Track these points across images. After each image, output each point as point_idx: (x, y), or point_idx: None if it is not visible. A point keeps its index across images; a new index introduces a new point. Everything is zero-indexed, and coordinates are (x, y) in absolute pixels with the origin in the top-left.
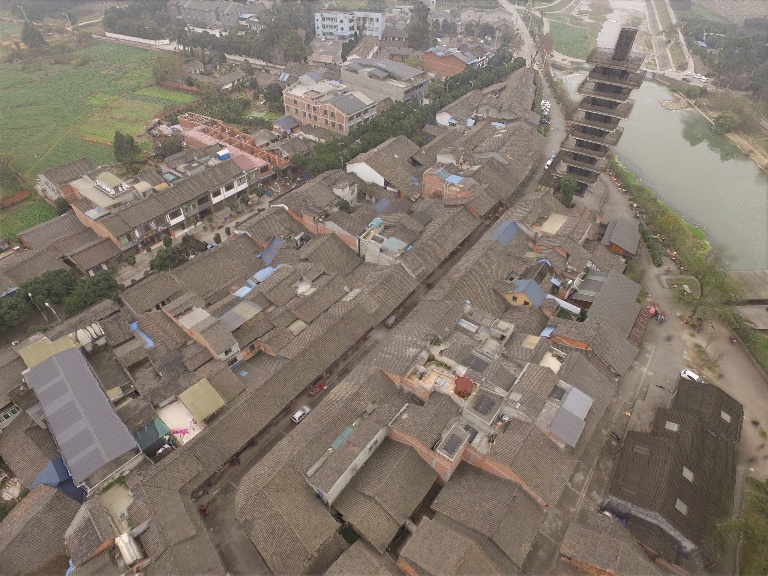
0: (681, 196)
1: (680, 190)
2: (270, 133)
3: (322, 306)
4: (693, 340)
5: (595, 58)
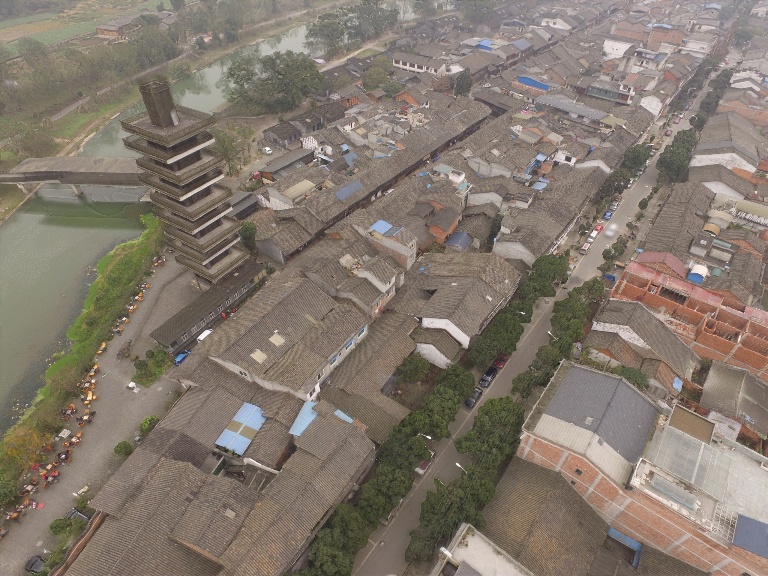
0: (37, 323)
1: (22, 334)
2: (722, 409)
3: (484, 147)
4: (244, 167)
5: (206, 115)
